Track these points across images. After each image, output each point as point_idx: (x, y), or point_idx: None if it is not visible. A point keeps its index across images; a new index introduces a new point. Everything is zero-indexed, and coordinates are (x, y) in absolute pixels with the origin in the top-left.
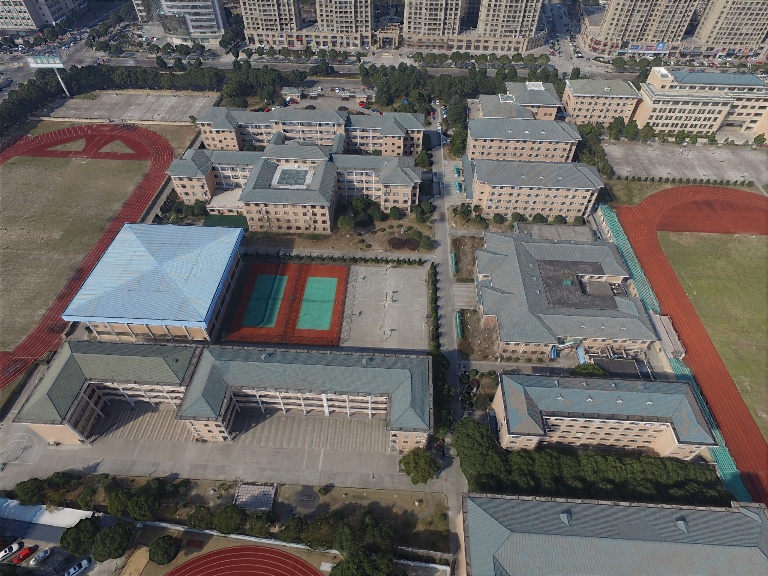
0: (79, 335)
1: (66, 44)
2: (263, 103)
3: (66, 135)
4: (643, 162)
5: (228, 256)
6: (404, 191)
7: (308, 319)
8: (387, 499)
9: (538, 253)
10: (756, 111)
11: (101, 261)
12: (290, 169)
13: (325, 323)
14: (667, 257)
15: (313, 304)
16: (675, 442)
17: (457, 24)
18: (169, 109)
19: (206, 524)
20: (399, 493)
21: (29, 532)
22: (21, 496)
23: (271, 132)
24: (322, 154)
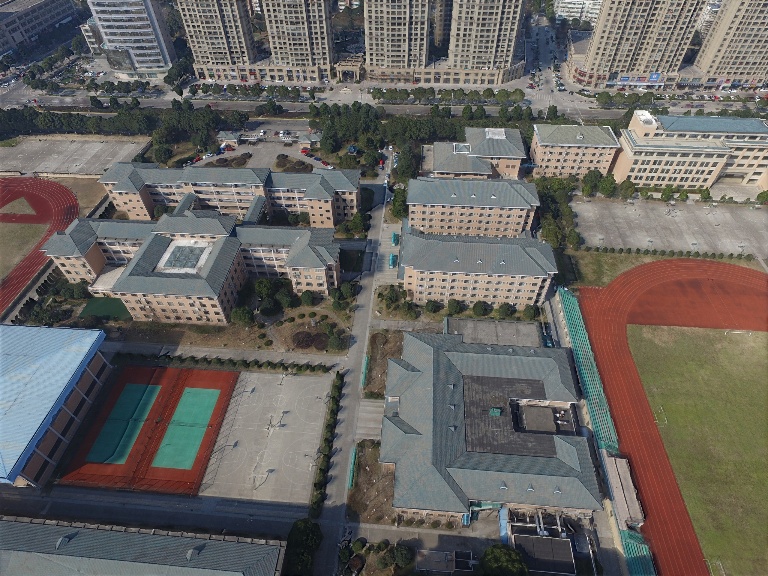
0: None
1: (7, 81)
2: (194, 151)
3: None
4: (620, 226)
5: (71, 373)
6: (316, 274)
7: (169, 452)
8: None
9: (464, 366)
10: (760, 162)
11: None
12: (185, 246)
13: (188, 459)
14: (636, 363)
15: (181, 429)
16: None
17: (424, 55)
18: (91, 158)
19: None
20: None
21: None
22: None
23: (184, 192)
24: (221, 228)
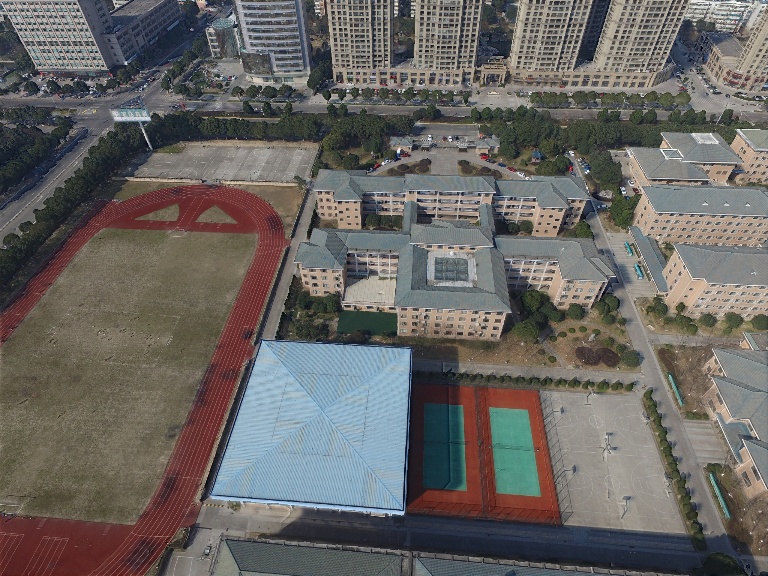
0: None
1: (139, 85)
2: (371, 157)
3: (156, 200)
4: None
5: (406, 395)
6: (591, 287)
7: (508, 477)
8: None
9: None
10: None
11: (245, 402)
12: (445, 257)
13: (533, 485)
14: None
15: (508, 452)
16: None
17: (574, 58)
18: (265, 165)
19: None
20: None
21: None
22: None
23: (399, 200)
24: (485, 239)
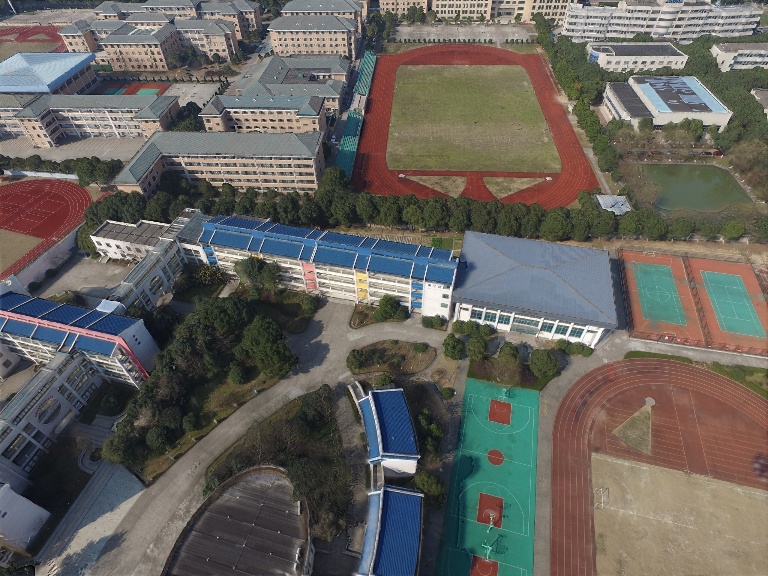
0: None
1: None
2: None
3: (6, 32)
4: (422, 34)
5: (77, 63)
6: (220, 41)
7: None
8: None
9: (291, 64)
10: None
11: None
12: (143, 29)
13: None
14: (396, 76)
15: None
16: (299, 119)
17: None
18: (87, 18)
19: (20, 163)
20: None
21: None
22: None
23: None
24: (165, 18)
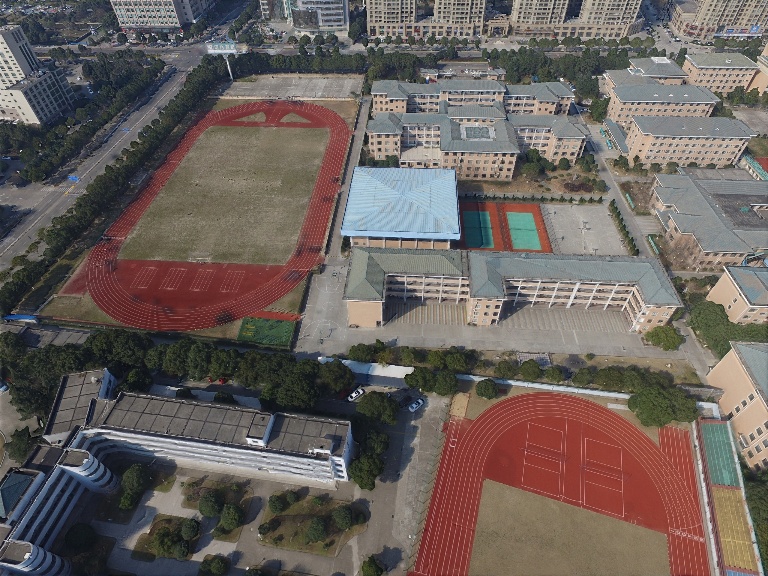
0: (334, 254)
1: (207, 39)
2: None
3: (245, 109)
4: (767, 124)
5: (454, 189)
6: (574, 144)
7: (520, 242)
8: (642, 363)
9: (711, 188)
10: None
11: (351, 193)
12: (472, 127)
13: (536, 245)
14: None
15: (520, 231)
16: None
17: (564, 13)
18: (324, 88)
19: (513, 373)
20: (650, 359)
21: (370, 380)
22: (359, 354)
23: (434, 101)
24: (501, 113)
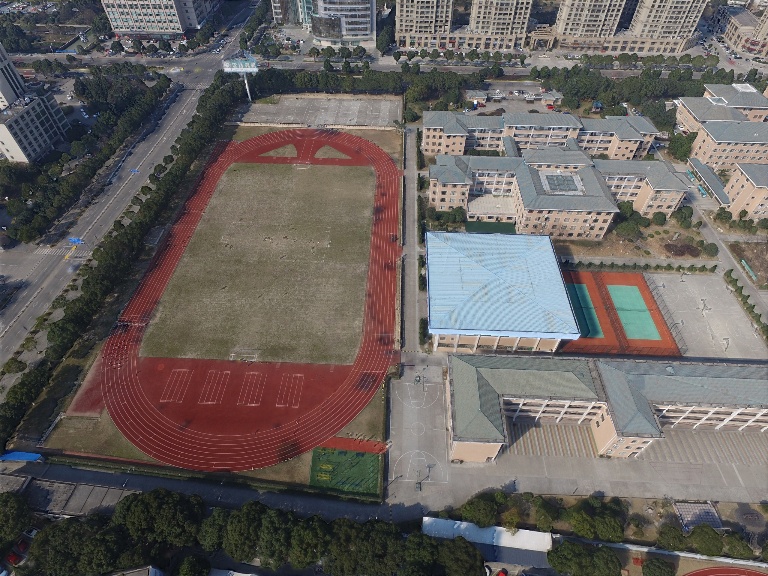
0: (411, 347)
1: (214, 47)
2: (453, 107)
3: (271, 140)
4: None
5: (556, 265)
6: (674, 196)
7: (634, 329)
8: None
9: None
10: None
11: (431, 271)
12: (553, 175)
13: (654, 333)
14: None
15: (629, 313)
16: None
17: (615, 25)
18: (359, 113)
19: (686, 545)
20: None
21: (498, 555)
22: (480, 518)
23: (496, 136)
24: (587, 159)
